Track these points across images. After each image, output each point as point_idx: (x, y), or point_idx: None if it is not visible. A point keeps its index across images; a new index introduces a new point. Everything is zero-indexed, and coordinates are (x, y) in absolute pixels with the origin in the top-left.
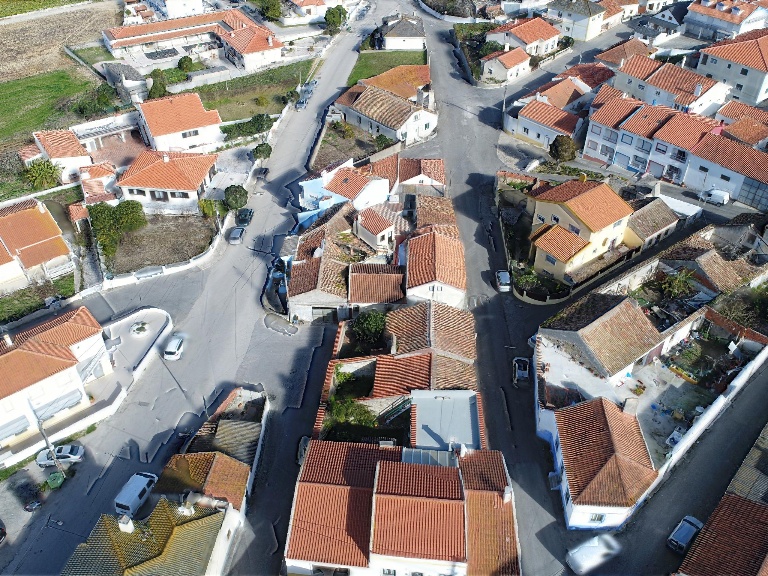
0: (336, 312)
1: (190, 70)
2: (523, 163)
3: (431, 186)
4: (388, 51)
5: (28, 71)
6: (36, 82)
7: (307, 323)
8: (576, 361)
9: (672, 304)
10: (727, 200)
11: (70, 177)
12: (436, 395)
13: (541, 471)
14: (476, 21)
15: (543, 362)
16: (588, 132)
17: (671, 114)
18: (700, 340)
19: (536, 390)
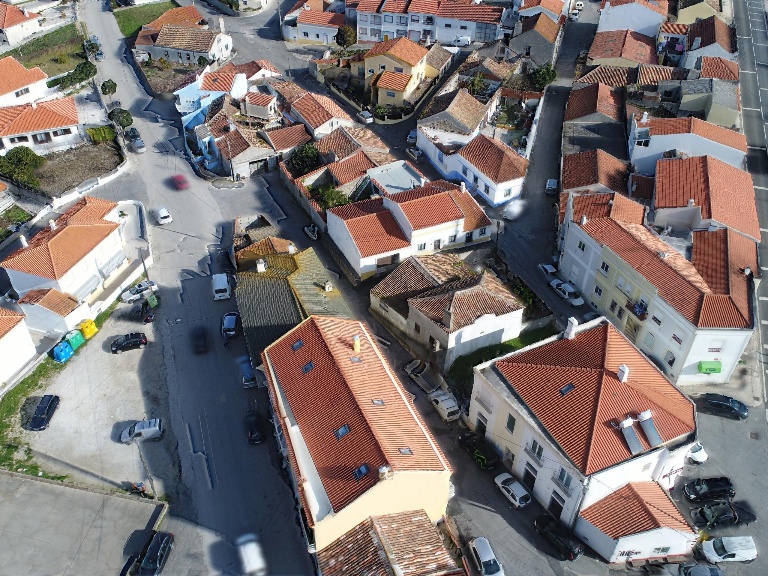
0: (267, 163)
1: None
2: (317, 56)
3: (272, 77)
4: (139, 6)
5: None
6: None
7: (247, 178)
8: (449, 132)
9: (478, 96)
10: (470, 42)
11: None
12: (382, 169)
13: None
14: None
15: (431, 137)
16: (358, 22)
17: None
18: (503, 110)
19: (433, 156)
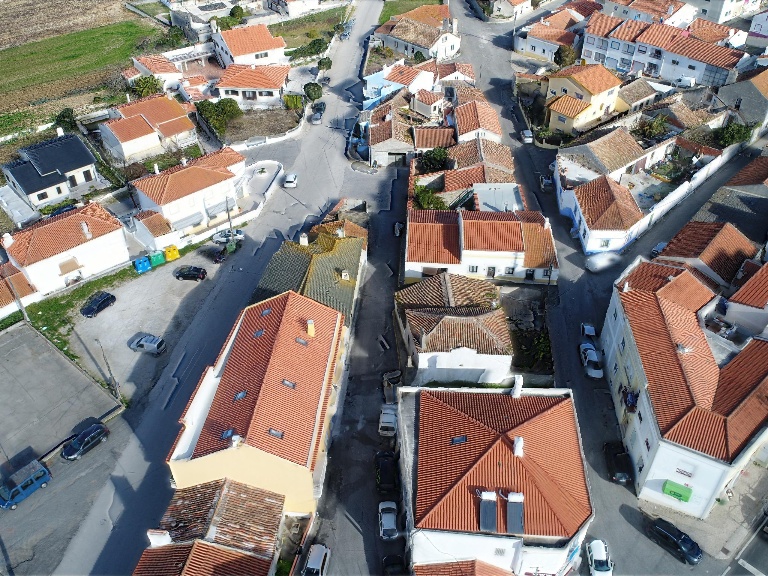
0: (405, 157)
1: (241, 17)
2: (533, 71)
3: (464, 81)
4: None
5: (99, 22)
6: (110, 30)
7: (383, 167)
8: (586, 167)
9: (652, 140)
10: (693, 84)
11: (167, 90)
12: (490, 187)
13: (565, 230)
14: None
15: (563, 168)
16: (584, 43)
17: (649, 24)
18: (673, 160)
19: (558, 188)
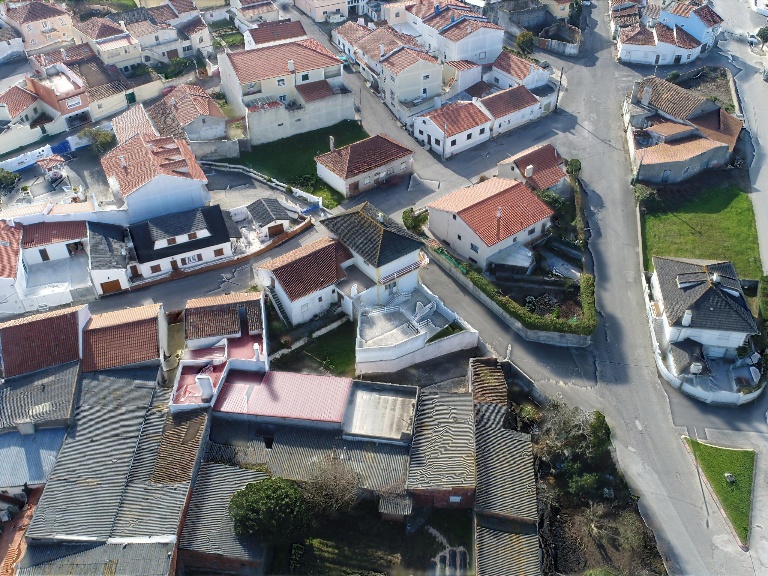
0: None
1: None
2: None
3: None
4: None
5: None
6: None
7: None
8: None
9: None
10: None
11: None
12: None
13: None
14: None
15: None
16: None
17: (451, 8)
18: None
19: None
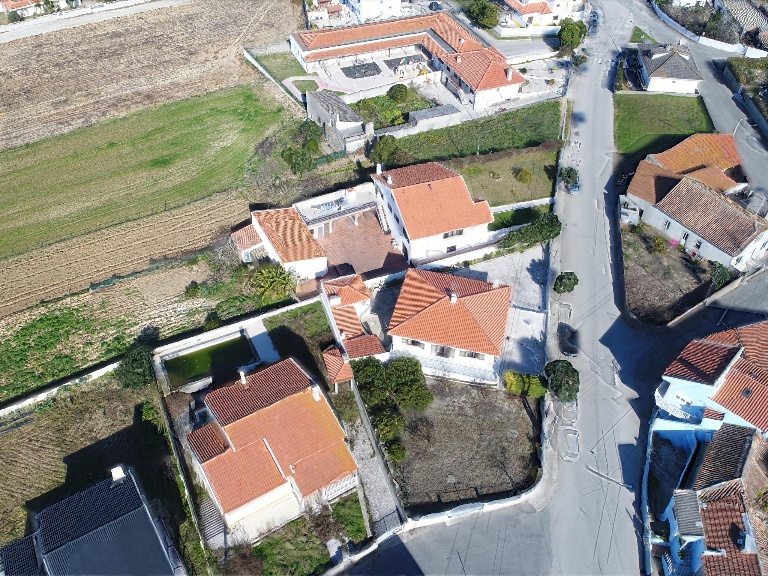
0: None
1: (404, 101)
2: None
3: None
4: (650, 93)
5: (206, 83)
6: (219, 102)
7: None
8: None
9: None
10: None
11: (300, 282)
12: None
13: None
14: (746, 50)
15: None
16: None
17: None
18: None
19: None
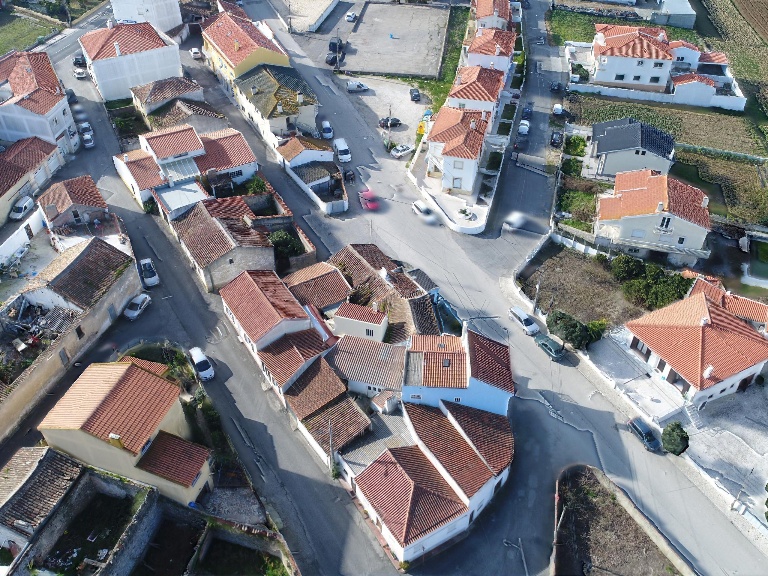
0: None
1: None
2: None
3: None
4: None
5: None
6: None
7: None
8: None
9: None
10: None
11: None
12: None
13: None
14: None
15: None
16: None
17: None
18: None
19: None
